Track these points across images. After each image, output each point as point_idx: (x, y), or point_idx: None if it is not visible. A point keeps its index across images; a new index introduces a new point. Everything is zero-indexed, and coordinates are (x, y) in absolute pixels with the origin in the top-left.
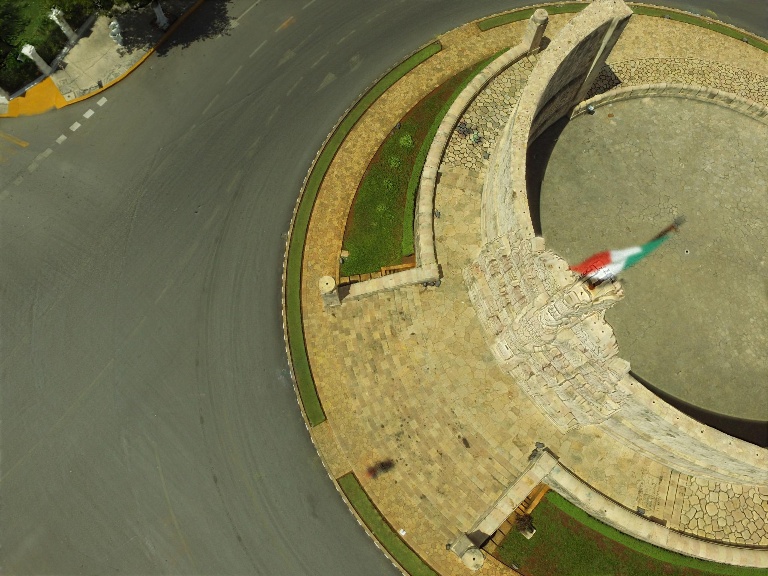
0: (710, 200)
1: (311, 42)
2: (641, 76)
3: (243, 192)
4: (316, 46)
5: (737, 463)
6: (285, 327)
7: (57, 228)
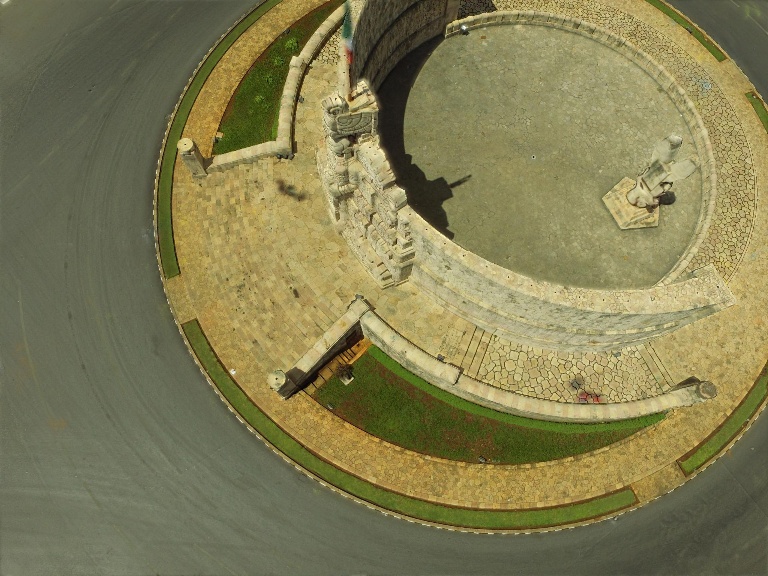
0: (562, 115)
1: None
2: (516, 6)
3: (136, 77)
4: None
5: (496, 288)
6: (156, 193)
7: None
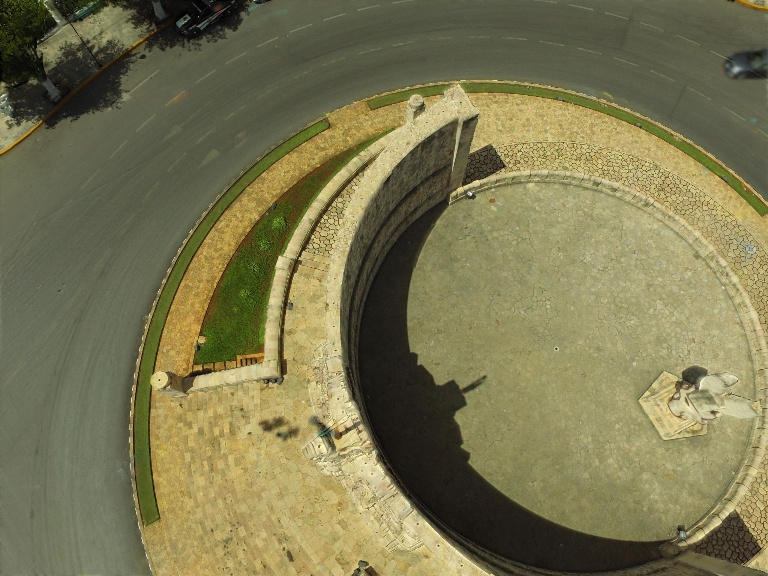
0: (586, 294)
1: (199, 117)
2: (527, 160)
3: (109, 271)
4: (204, 121)
5: None
6: (132, 416)
7: None
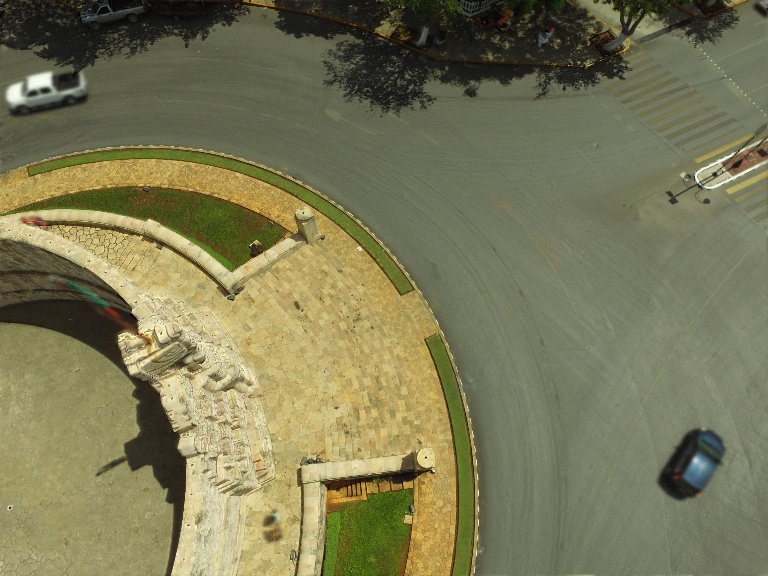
0: None
1: None
2: None
3: None
4: None
5: None
6: (471, 432)
7: (762, 570)
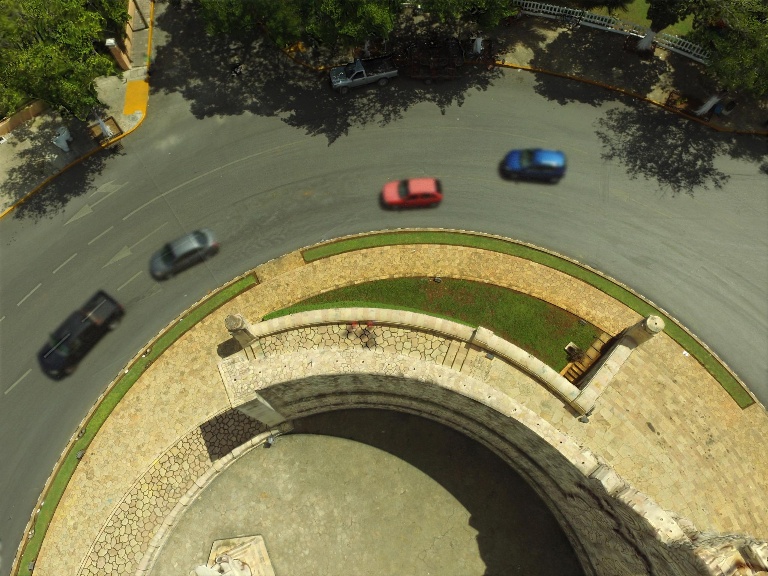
0: None
1: None
2: None
3: None
4: None
5: None
6: None
7: None
